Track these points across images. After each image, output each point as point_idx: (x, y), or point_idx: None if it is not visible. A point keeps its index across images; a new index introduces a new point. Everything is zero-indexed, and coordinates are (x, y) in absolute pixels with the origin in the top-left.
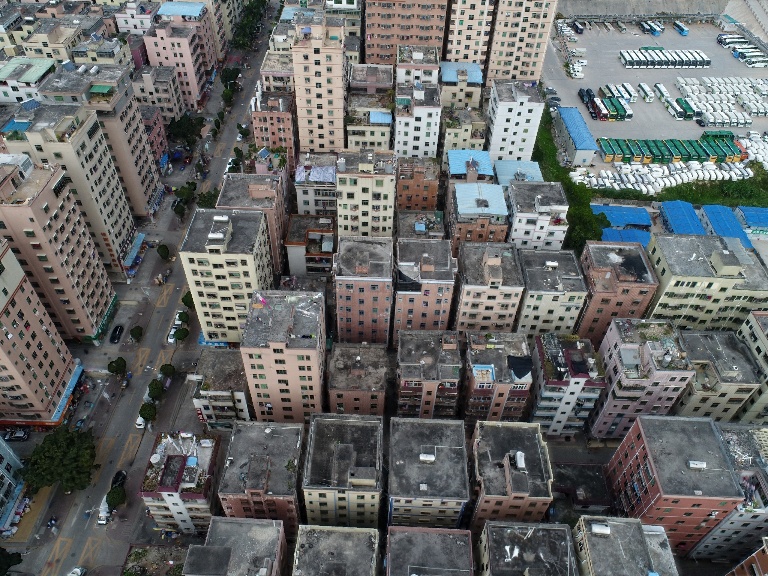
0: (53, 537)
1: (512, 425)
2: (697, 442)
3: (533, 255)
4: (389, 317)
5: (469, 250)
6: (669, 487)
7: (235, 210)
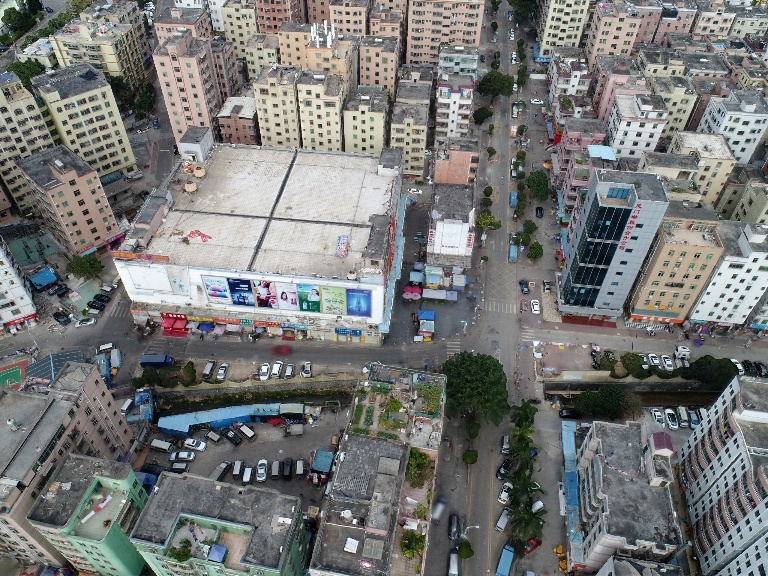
0: (492, 120)
1: (742, 55)
2: None
3: (735, 8)
4: (652, 39)
5: (699, 3)
6: None
7: None
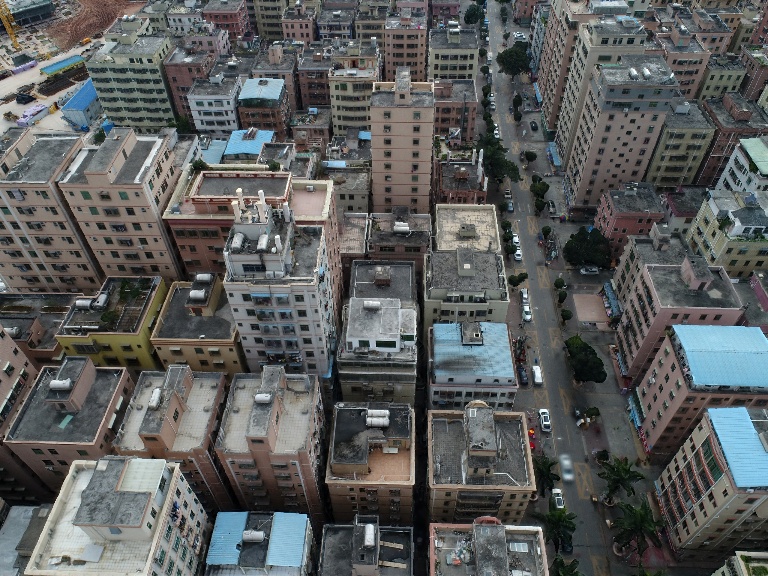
0: None
1: (294, 21)
2: (216, 8)
3: None
4: None
5: None
6: (240, 0)
7: (451, 49)
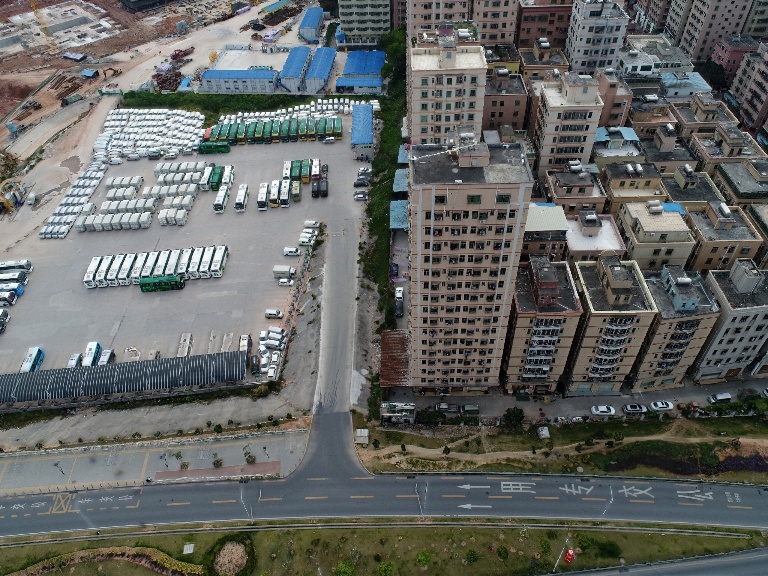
0: None
1: None
2: None
3: None
4: None
5: None
6: None
7: None
